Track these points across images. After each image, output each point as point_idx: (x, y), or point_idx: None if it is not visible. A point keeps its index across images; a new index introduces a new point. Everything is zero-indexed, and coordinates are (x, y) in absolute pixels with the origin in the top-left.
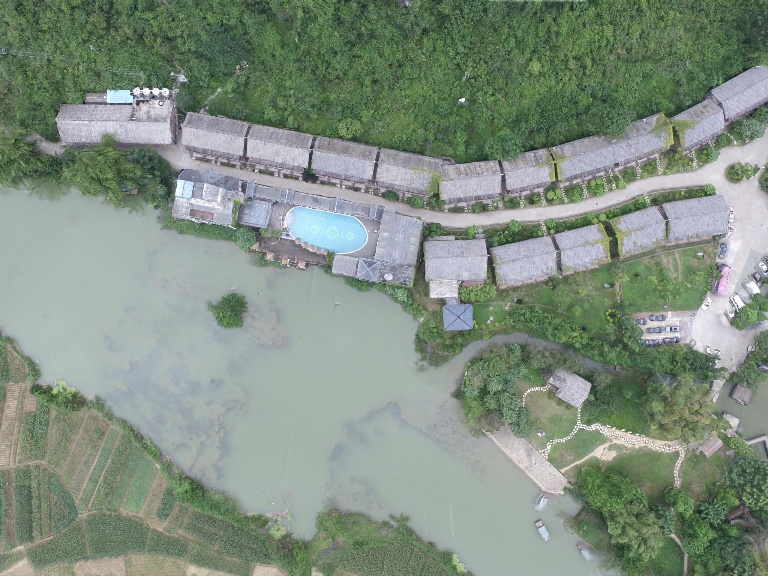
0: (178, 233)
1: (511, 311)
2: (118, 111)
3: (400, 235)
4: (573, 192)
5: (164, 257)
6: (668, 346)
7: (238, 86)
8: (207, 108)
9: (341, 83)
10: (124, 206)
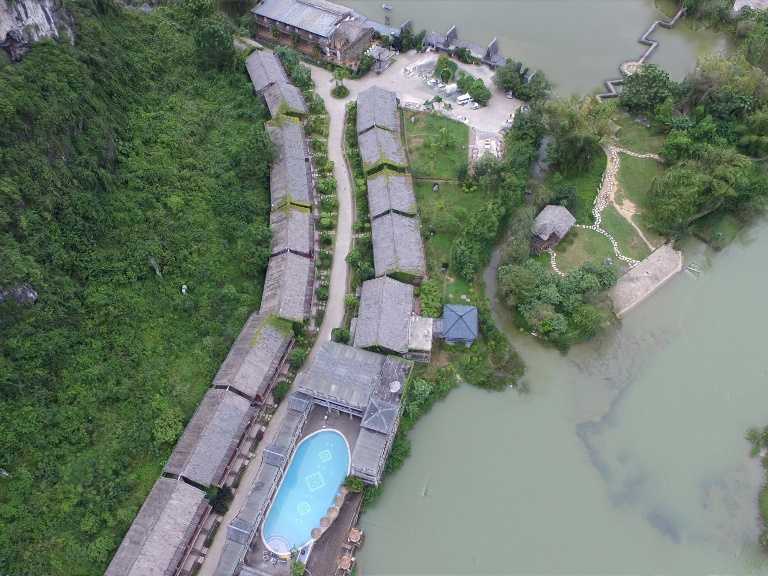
0: None
1: (457, 268)
2: None
3: (339, 370)
4: (327, 204)
5: None
6: (505, 149)
7: None
8: None
9: (101, 430)
10: None
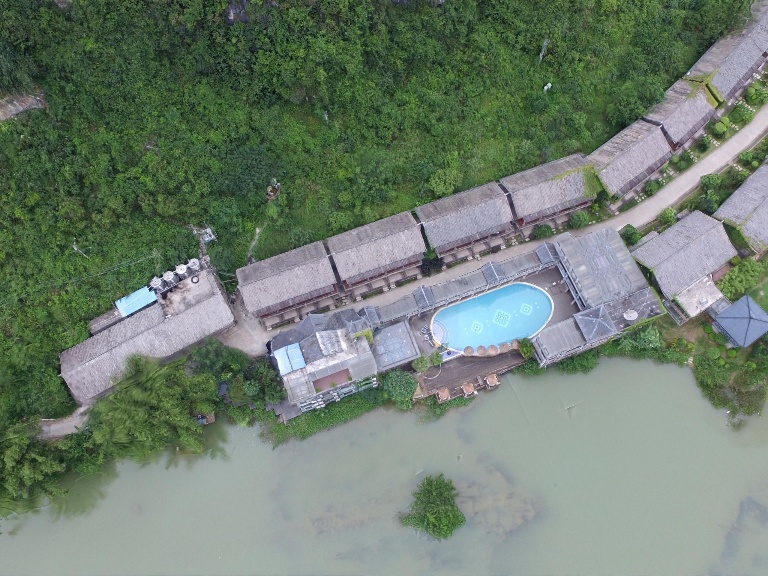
0: (299, 441)
1: None
2: (143, 319)
3: (600, 259)
4: (739, 112)
5: (297, 487)
6: None
7: (281, 210)
8: (254, 260)
9: (401, 142)
10: (205, 448)
